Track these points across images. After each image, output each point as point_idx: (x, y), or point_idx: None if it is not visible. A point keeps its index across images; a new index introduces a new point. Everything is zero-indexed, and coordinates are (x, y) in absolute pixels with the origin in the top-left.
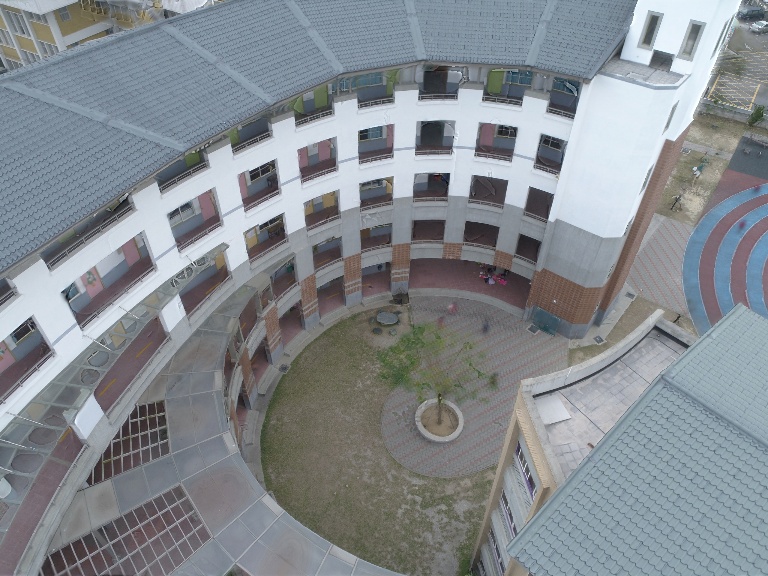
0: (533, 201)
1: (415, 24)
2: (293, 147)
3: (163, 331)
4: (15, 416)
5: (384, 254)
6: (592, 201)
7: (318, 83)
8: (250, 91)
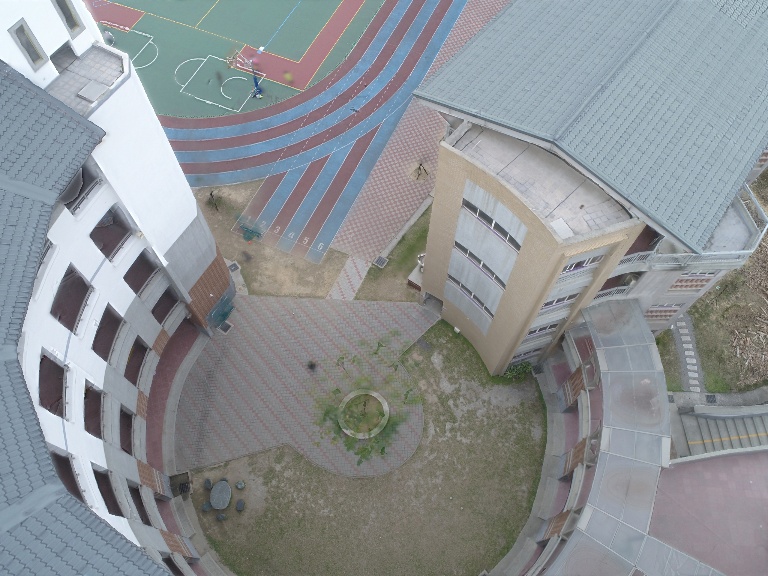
0: (133, 280)
1: None
2: None
3: None
4: None
5: None
6: (169, 209)
7: (104, 522)
8: None
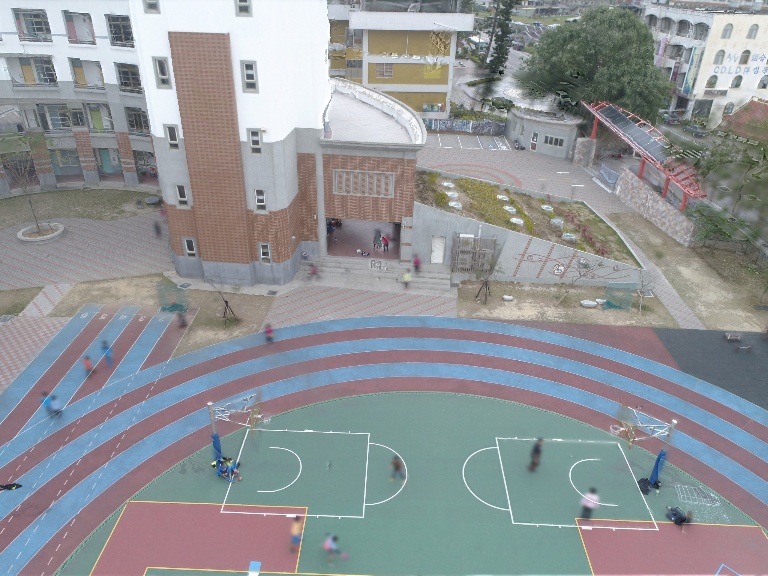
0: None
1: None
2: (100, 10)
3: None
4: None
5: None
6: None
7: None
8: None
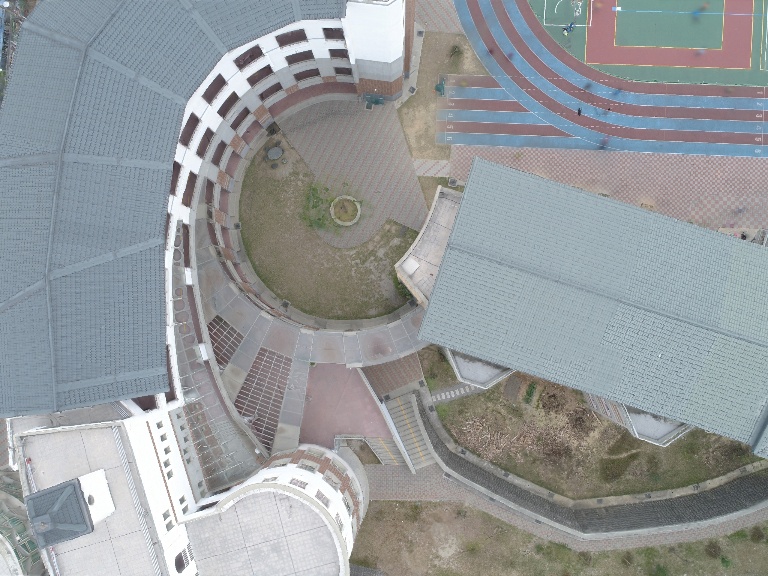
0: (334, 52)
1: (199, 19)
2: None
3: (188, 286)
4: (181, 378)
5: (250, 120)
6: (375, 50)
7: None
8: (154, 169)
